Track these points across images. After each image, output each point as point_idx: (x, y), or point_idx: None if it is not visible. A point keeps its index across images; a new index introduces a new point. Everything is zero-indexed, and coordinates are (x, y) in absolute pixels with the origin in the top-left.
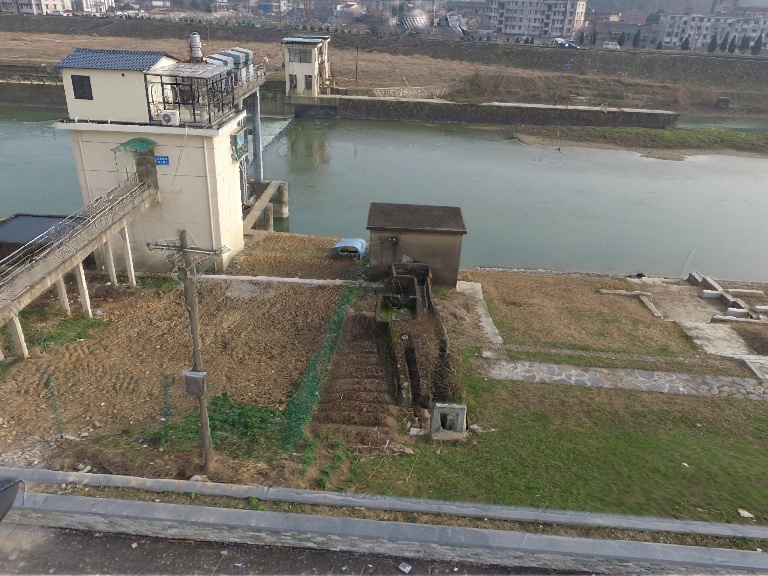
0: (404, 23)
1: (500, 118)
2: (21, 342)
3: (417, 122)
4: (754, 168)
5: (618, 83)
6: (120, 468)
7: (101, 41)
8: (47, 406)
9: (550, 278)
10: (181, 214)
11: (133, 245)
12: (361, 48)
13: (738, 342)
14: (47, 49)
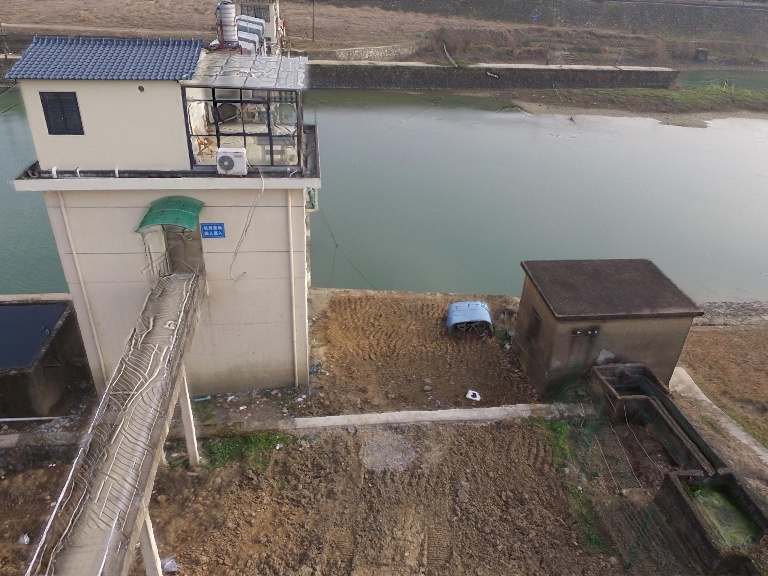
0: None
1: (489, 82)
2: None
3: (397, 90)
4: None
5: (591, 35)
6: None
7: None
8: None
9: (732, 334)
10: (242, 310)
11: None
12: (317, 1)
13: None
14: None
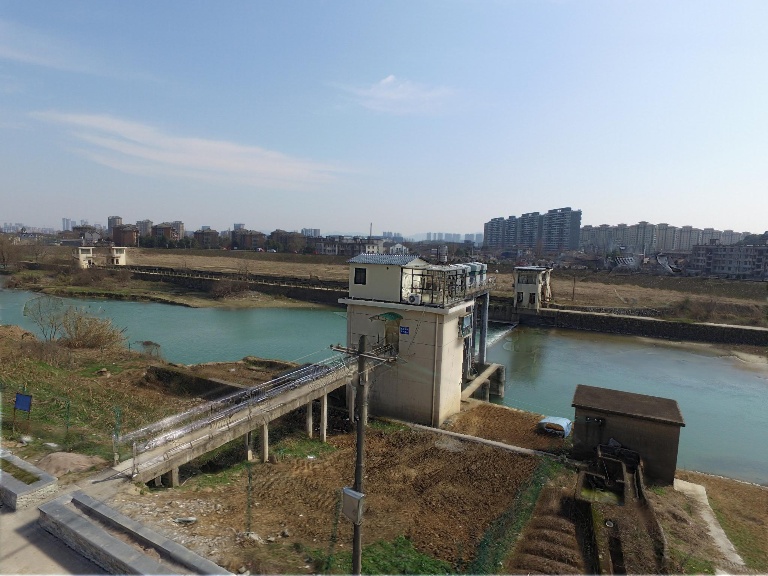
0: (616, 261)
1: (714, 337)
2: (265, 447)
3: (627, 334)
4: None
5: None
6: None
7: None
8: (259, 505)
9: None
10: (412, 373)
11: (373, 394)
12: (578, 276)
13: None
14: None
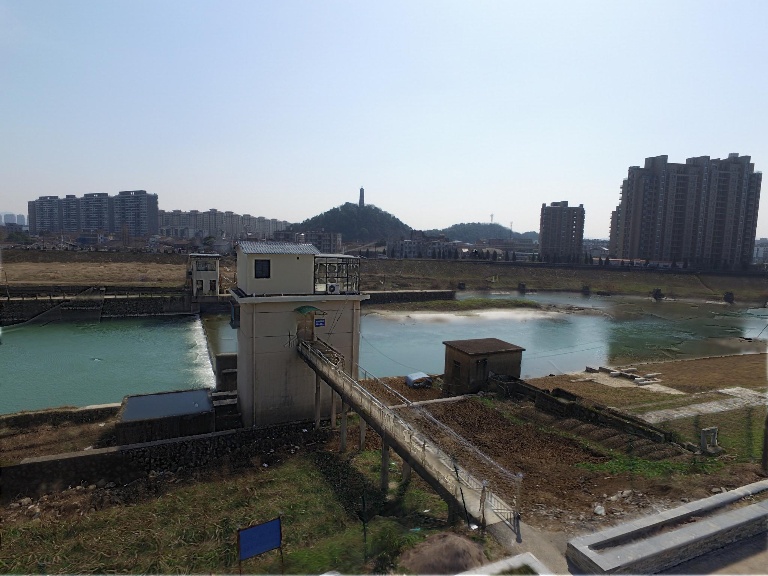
0: None
1: None
2: None
3: None
4: (516, 316)
5: (400, 278)
6: (736, 482)
7: None
8: None
9: None
10: None
11: (284, 400)
12: None
13: (675, 390)
14: None
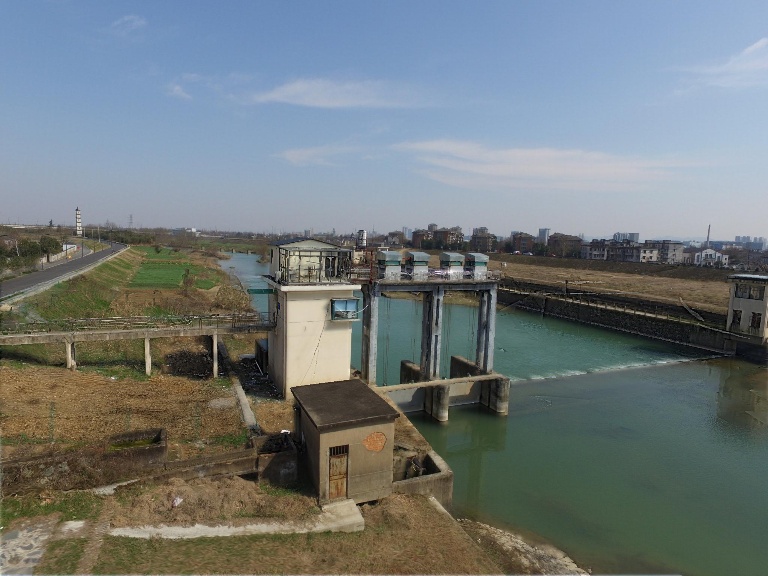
0: None
1: None
2: (67, 358)
3: None
4: None
5: None
6: None
7: (643, 278)
8: None
9: None
10: (280, 346)
11: None
12: None
13: None
14: (592, 280)
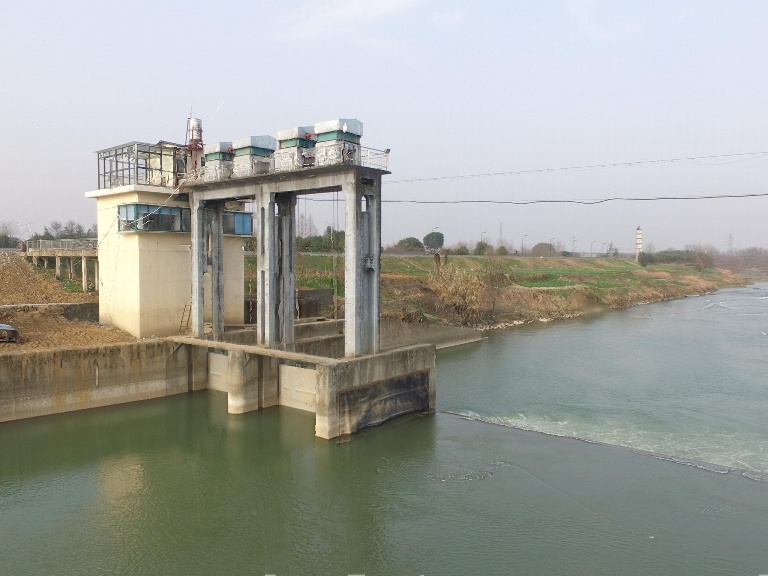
0: None
1: None
2: None
3: None
4: None
5: None
6: None
7: None
8: None
9: None
10: None
11: None
12: None
13: None
14: None
